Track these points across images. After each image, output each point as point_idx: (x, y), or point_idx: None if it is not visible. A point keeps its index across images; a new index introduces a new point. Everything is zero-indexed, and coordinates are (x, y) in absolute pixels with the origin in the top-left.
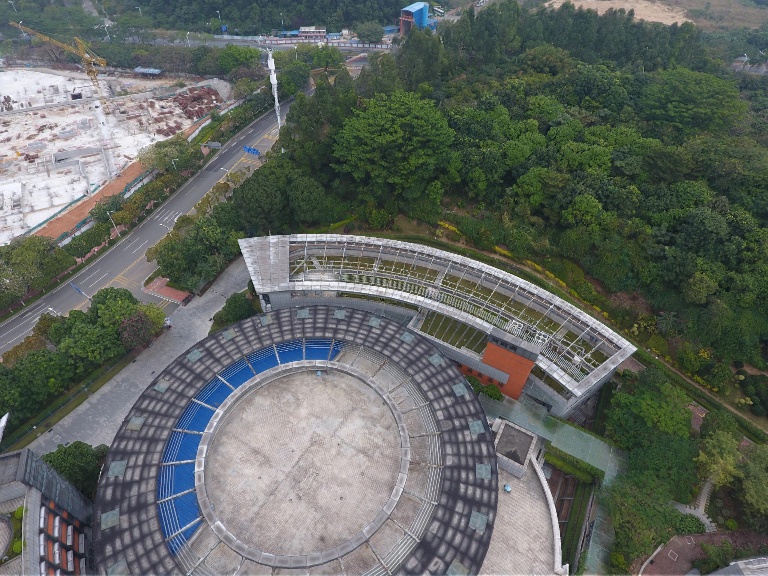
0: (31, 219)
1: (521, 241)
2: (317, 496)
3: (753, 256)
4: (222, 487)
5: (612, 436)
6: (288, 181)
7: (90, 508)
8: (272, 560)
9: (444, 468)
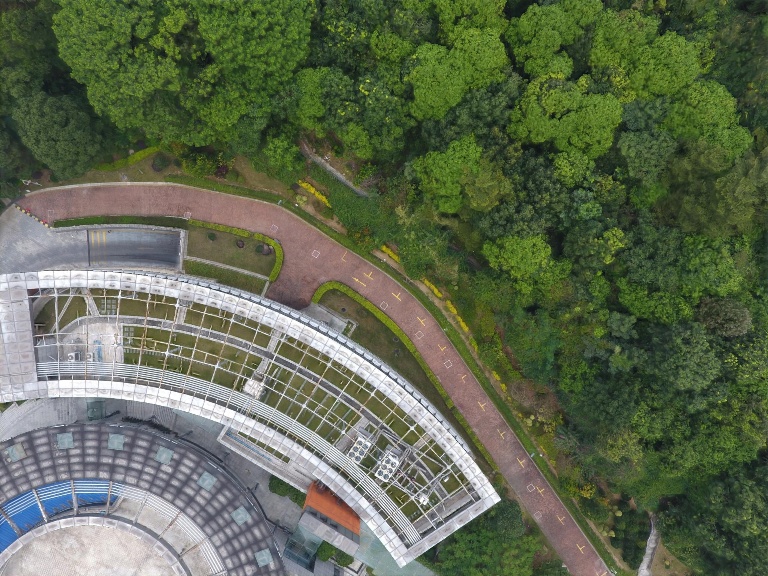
0: None
1: (418, 256)
2: None
3: (724, 417)
4: None
5: (440, 566)
6: (10, 94)
7: None
8: None
9: None
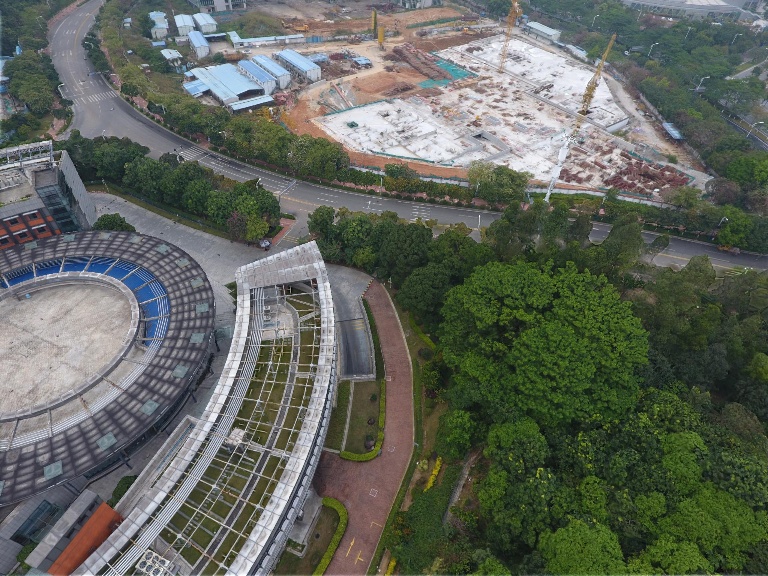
0: (395, 149)
1: None
2: (6, 360)
3: None
4: (44, 299)
5: None
6: None
7: None
8: None
9: None
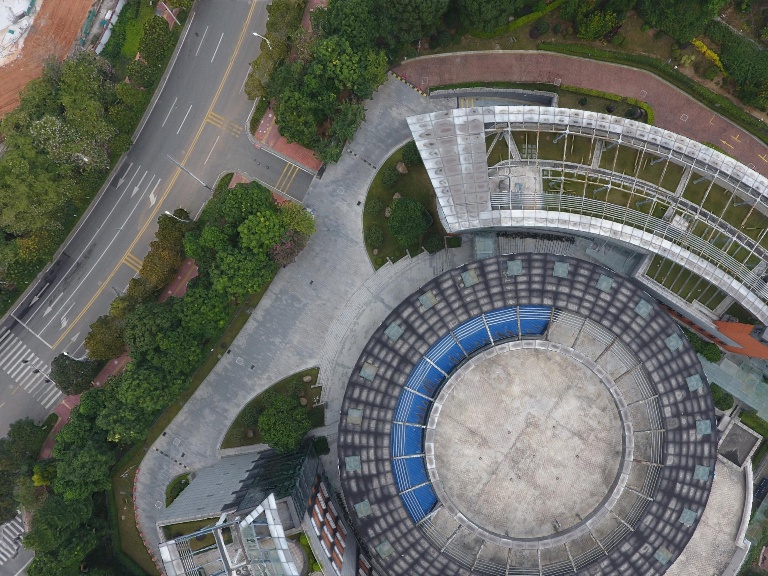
0: None
1: None
2: (535, 476)
3: None
4: (447, 466)
5: None
6: None
7: (312, 449)
8: (510, 545)
9: (664, 468)
